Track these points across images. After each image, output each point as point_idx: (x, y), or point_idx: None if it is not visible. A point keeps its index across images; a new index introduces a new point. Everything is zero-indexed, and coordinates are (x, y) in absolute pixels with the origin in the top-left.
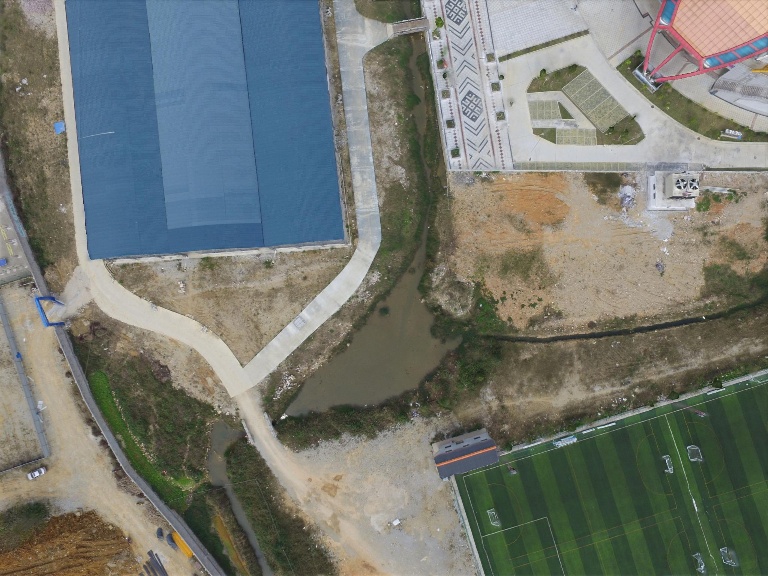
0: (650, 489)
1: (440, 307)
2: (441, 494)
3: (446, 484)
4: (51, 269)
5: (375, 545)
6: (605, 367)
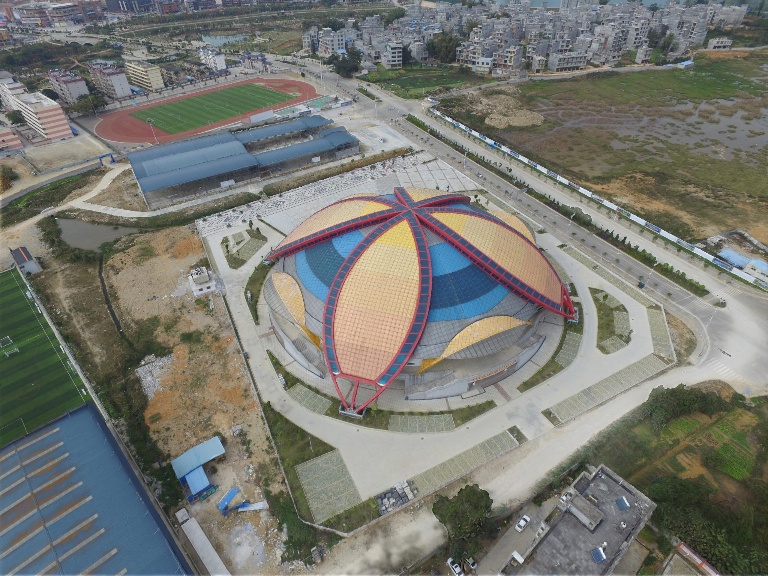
0: None
1: (119, 240)
2: (1, 268)
3: None
4: (127, 159)
5: None
6: None
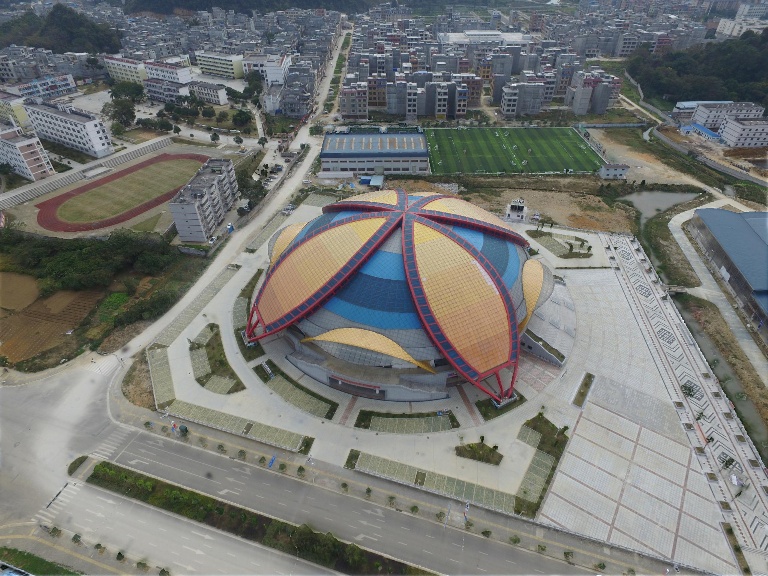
0: None
1: (630, 206)
2: None
3: None
4: None
5: None
6: None
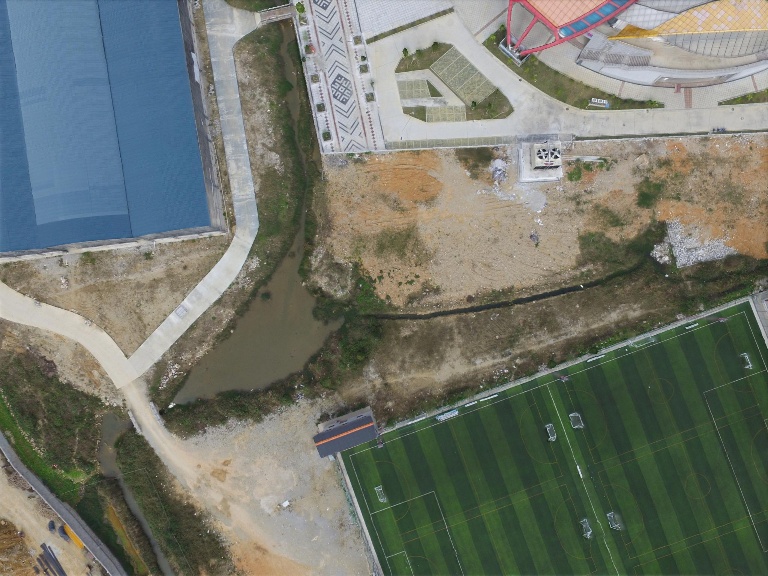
0: (535, 458)
1: (320, 289)
2: (329, 474)
3: (333, 464)
4: None
5: (266, 527)
6: (485, 340)
